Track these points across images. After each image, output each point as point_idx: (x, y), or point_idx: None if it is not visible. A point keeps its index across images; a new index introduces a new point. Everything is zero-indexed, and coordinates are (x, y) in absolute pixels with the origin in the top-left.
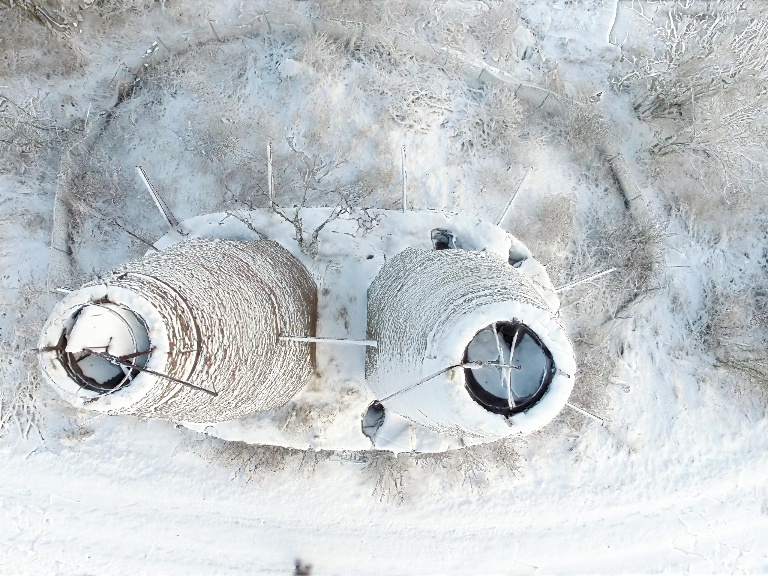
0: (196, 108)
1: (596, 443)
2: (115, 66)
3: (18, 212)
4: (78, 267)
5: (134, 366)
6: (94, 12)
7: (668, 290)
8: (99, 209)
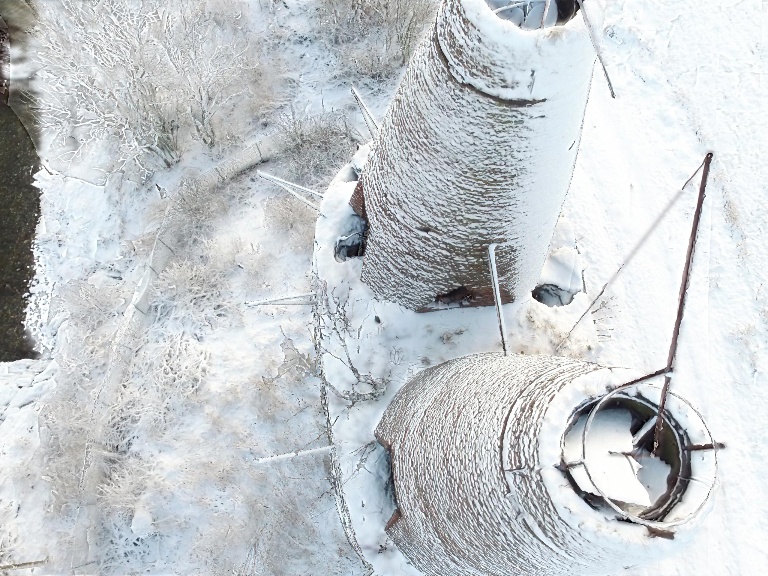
0: None
1: None
2: None
3: None
4: None
5: (674, 338)
6: None
7: None
8: None
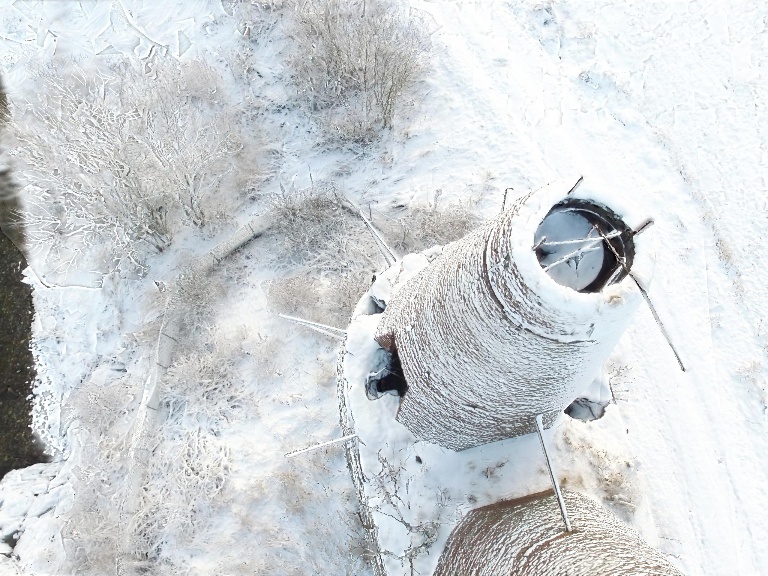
0: None
1: (494, 209)
2: None
3: None
4: None
5: None
6: None
7: None
8: None
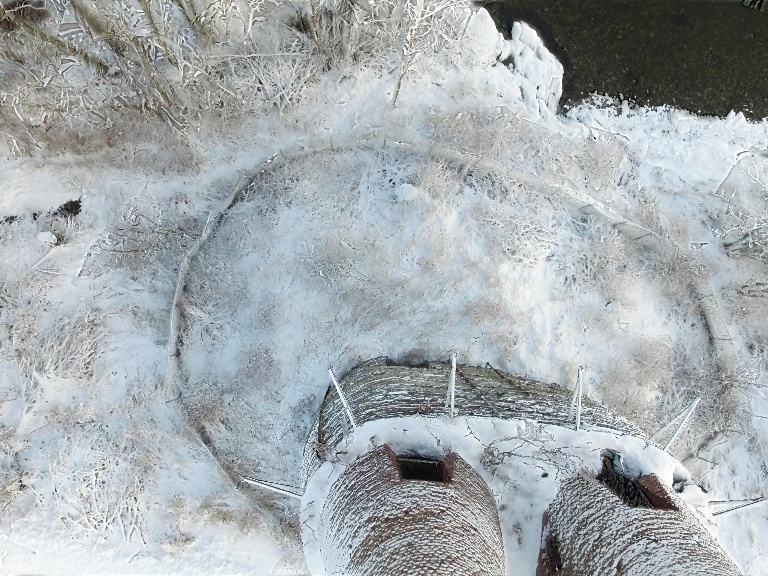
0: (311, 221)
1: None
2: (229, 166)
3: (129, 309)
4: (184, 368)
5: None
6: (213, 112)
7: (746, 429)
8: (208, 312)
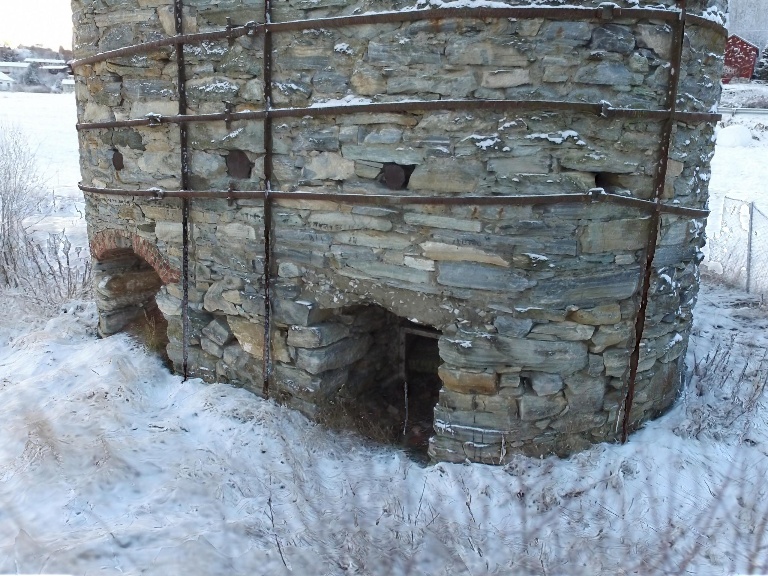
0: None
1: None
2: None
3: None
4: None
5: None
6: None
7: None
8: None
